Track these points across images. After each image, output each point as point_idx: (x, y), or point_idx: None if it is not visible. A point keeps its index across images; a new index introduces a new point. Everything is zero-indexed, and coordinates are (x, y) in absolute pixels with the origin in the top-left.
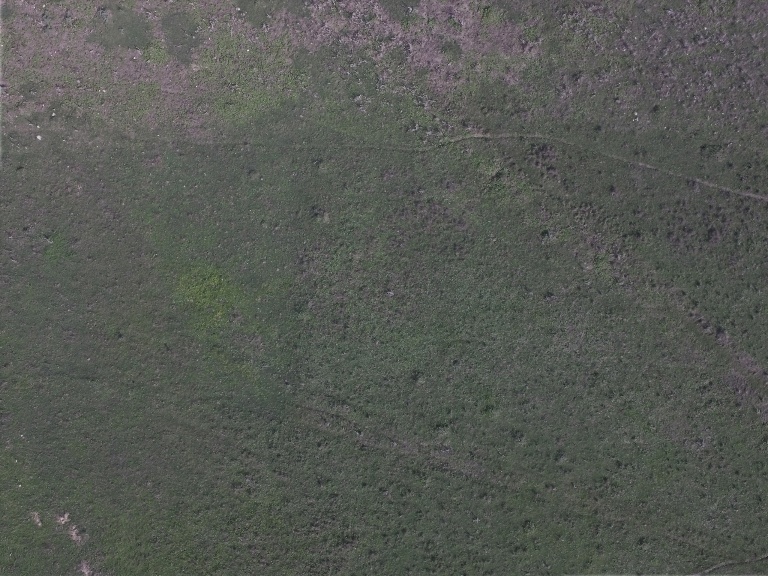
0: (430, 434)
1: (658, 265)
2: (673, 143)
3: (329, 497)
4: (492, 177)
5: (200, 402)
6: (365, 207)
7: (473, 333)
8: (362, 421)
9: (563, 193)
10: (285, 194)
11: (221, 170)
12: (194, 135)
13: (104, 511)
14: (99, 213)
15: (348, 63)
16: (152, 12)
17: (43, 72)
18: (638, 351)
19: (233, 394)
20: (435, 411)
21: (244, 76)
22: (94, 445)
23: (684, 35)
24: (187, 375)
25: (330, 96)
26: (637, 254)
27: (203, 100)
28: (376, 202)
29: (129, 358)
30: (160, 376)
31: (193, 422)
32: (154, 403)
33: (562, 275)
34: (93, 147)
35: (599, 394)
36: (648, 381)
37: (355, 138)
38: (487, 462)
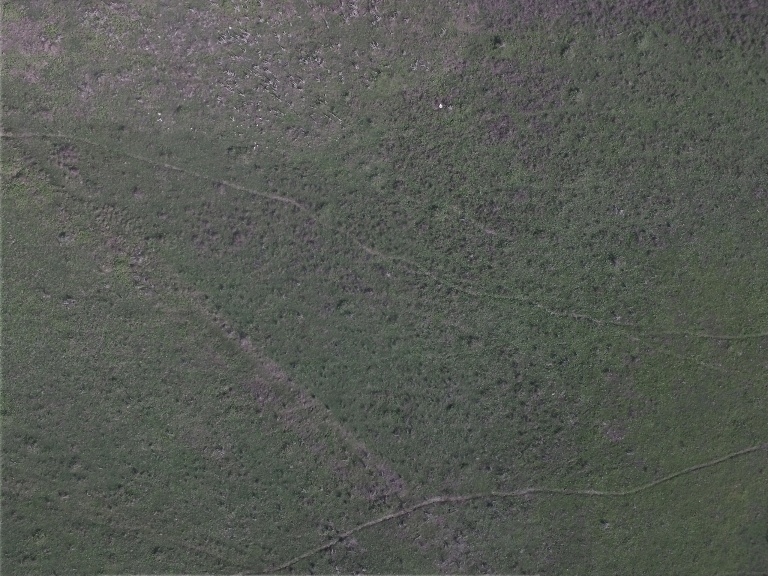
0: None
1: (181, 268)
2: (200, 144)
3: None
4: (12, 177)
5: None
6: None
7: None
8: None
9: (86, 194)
10: None
11: None
12: None
13: None
14: None
15: None
16: None
17: None
18: (158, 356)
19: None
20: None
21: None
22: None
23: (209, 34)
24: None
25: None
26: (160, 257)
27: None
28: None
29: None
30: None
31: None
32: None
33: (82, 278)
34: None
35: (117, 400)
36: (167, 387)
37: None
38: None
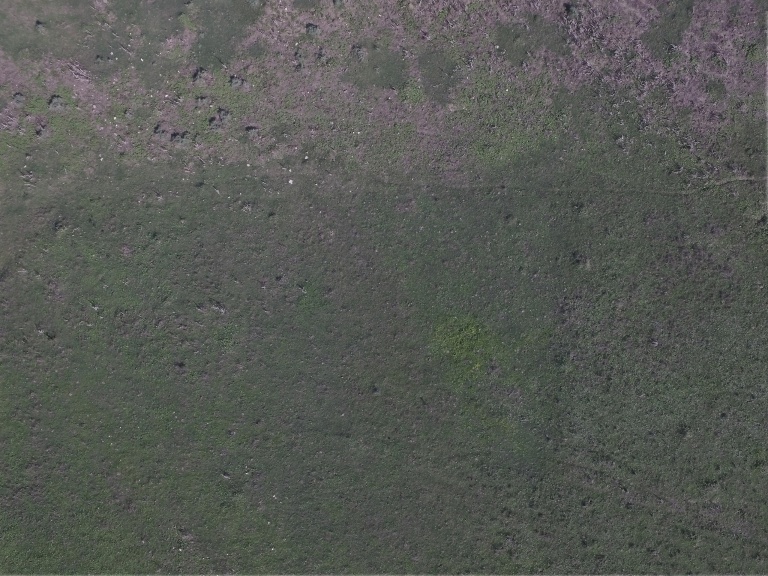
0: (698, 491)
1: None
2: None
3: (595, 558)
4: (758, 221)
5: (458, 459)
6: (628, 253)
7: (741, 384)
8: (627, 477)
9: None
10: (544, 240)
11: (477, 215)
12: (450, 178)
13: (359, 575)
14: (352, 261)
15: (610, 103)
16: (409, 50)
17: (296, 113)
18: None
19: (491, 450)
20: (703, 466)
21: (503, 117)
22: (349, 505)
23: None
24: (444, 430)
25: (591, 137)
26: None
27: (460, 142)
28: (639, 248)
29: (384, 413)
30: (416, 432)
31: (451, 480)
32: (410, 460)
33: None
34: (346, 191)
35: None
36: None
37: (616, 181)
38: (758, 520)
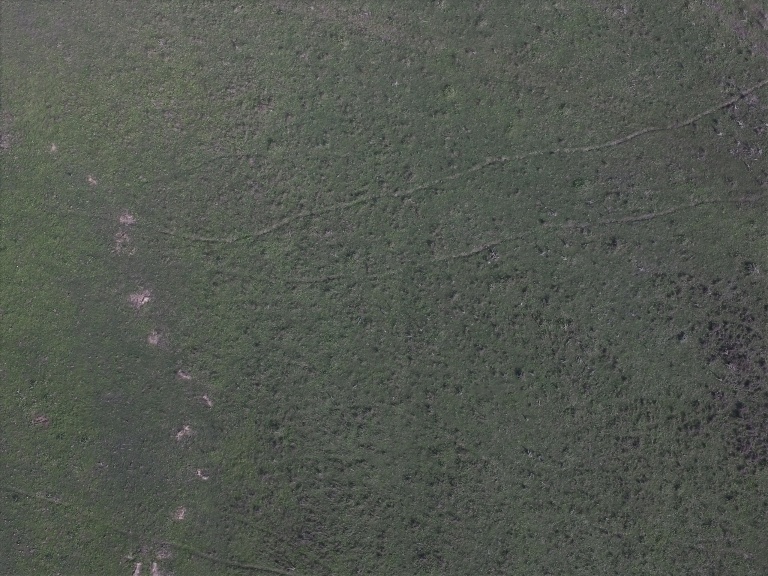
0: None
1: None
2: None
3: (245, 60)
4: None
5: None
6: None
7: None
8: None
9: None
10: None
11: None
12: None
13: (12, 73)
14: None
15: None
16: None
17: None
18: None
19: None
20: None
21: None
22: (1, 4)
23: None
24: None
25: None
26: None
27: None
28: None
29: None
30: None
31: None
32: None
33: None
34: None
35: None
36: None
37: None
38: (406, 27)
